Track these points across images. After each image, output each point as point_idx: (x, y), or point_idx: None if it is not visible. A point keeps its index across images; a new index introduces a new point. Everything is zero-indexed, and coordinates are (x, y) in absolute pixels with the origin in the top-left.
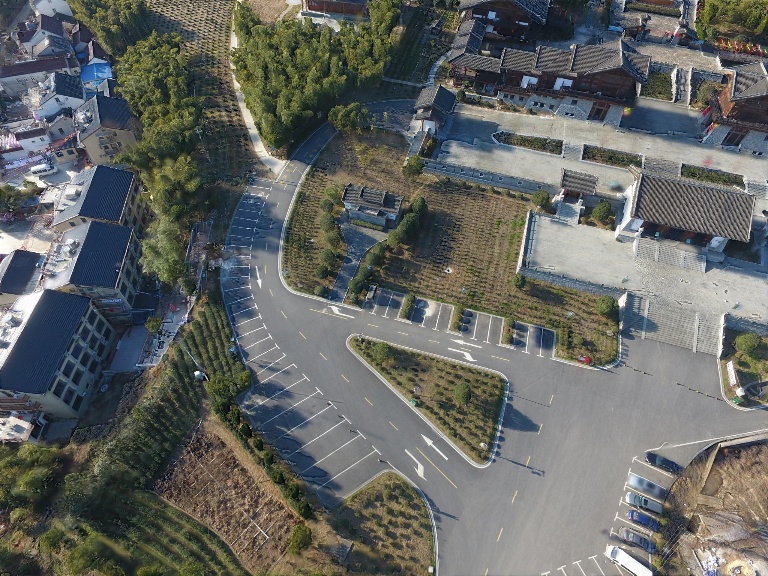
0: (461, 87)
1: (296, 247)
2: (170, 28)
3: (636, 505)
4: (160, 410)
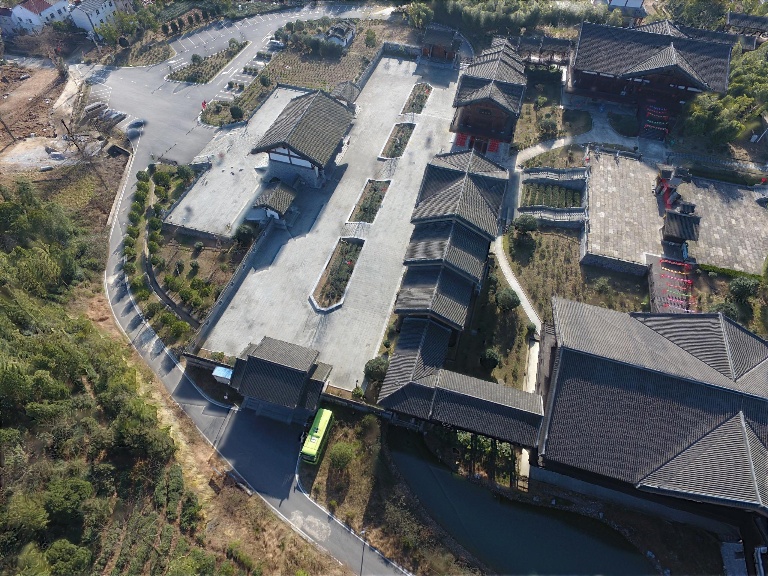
0: None
1: None
2: None
3: None
4: None
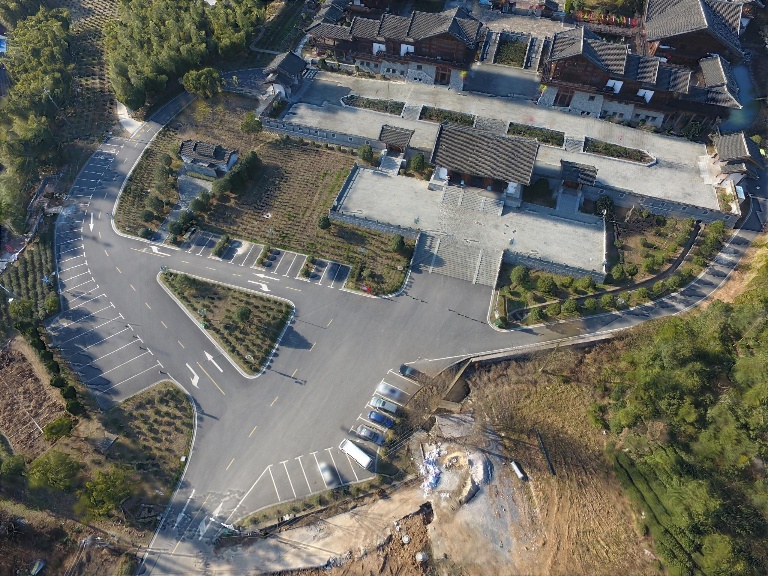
0: (324, 56)
1: (131, 196)
2: (70, 6)
3: (376, 407)
4: None
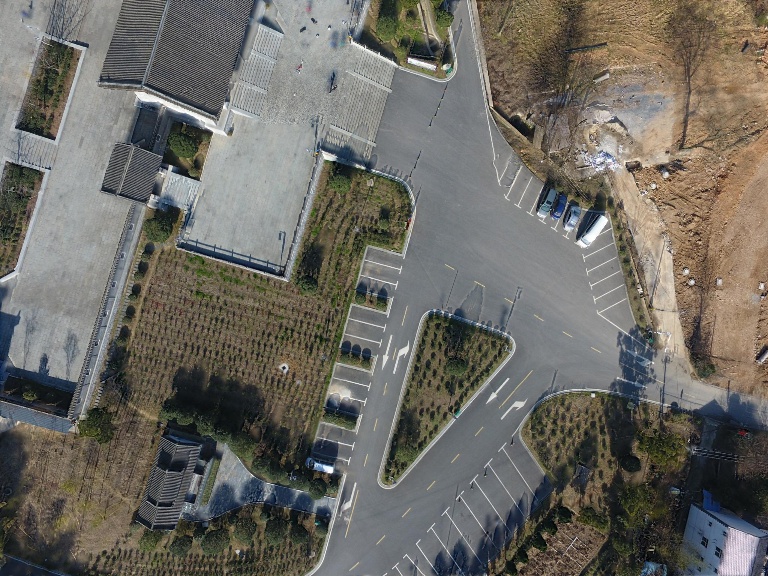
0: None
1: None
2: None
3: None
4: None
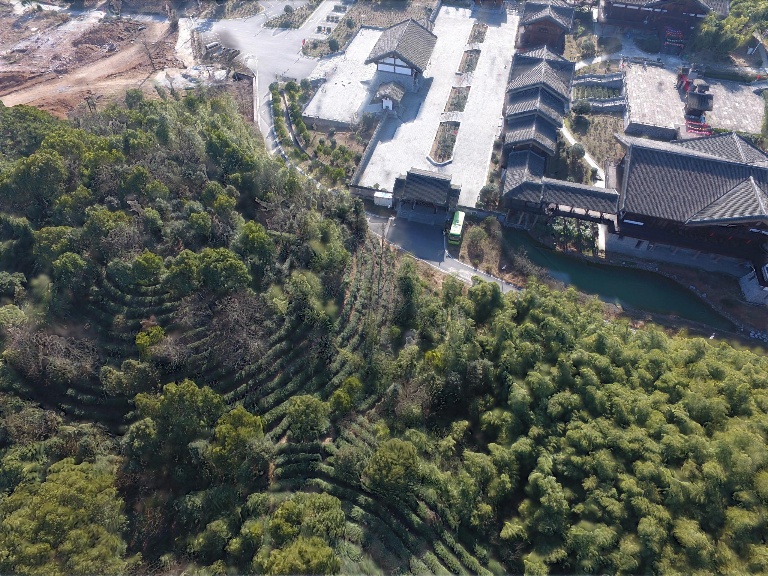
0: None
1: None
2: None
3: None
4: None
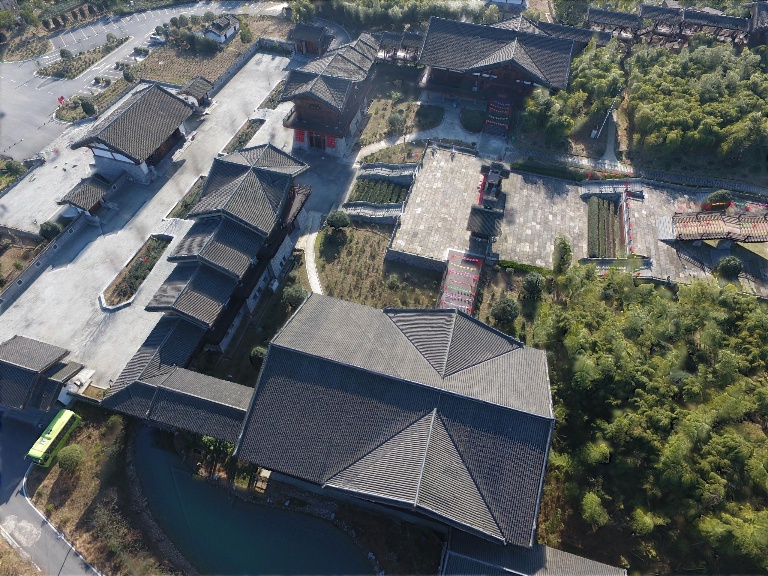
0: None
1: None
2: None
3: None
4: (122, 0)
